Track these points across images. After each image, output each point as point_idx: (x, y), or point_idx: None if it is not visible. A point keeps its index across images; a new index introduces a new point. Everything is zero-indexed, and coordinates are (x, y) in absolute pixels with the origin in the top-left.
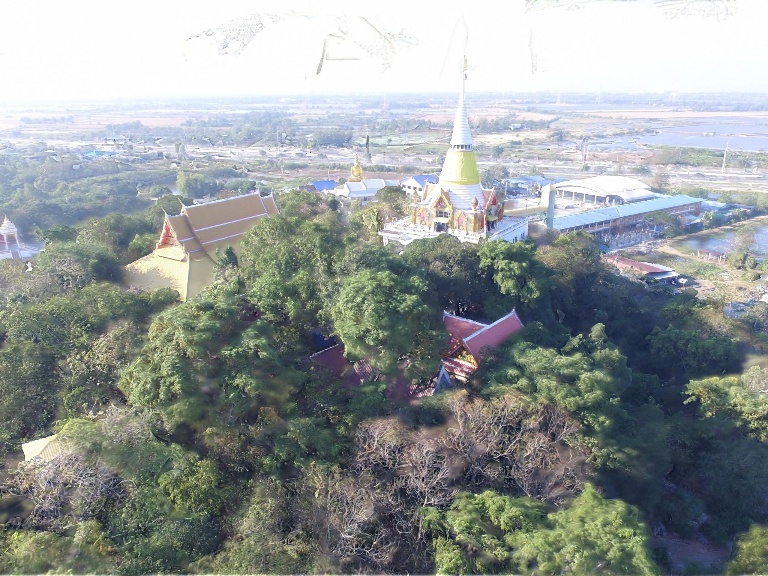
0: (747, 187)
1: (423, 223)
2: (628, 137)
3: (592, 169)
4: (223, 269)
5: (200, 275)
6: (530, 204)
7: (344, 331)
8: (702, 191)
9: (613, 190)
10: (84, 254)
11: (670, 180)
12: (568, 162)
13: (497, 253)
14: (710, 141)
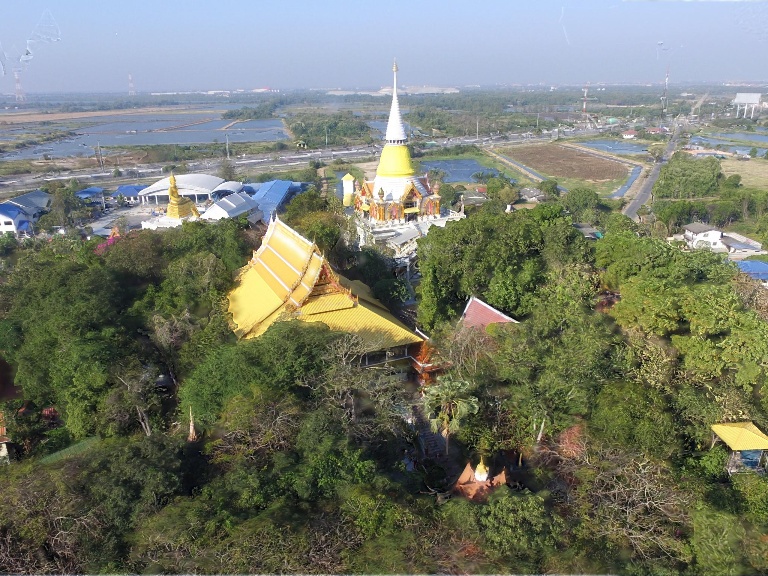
0: (266, 170)
1: (393, 218)
2: (60, 141)
3: (124, 174)
4: (437, 291)
5: (381, 314)
6: (139, 215)
7: (674, 274)
8: (269, 176)
9: (209, 186)
10: (319, 331)
11: (237, 171)
12: (73, 171)
13: (556, 213)
14: (147, 138)
